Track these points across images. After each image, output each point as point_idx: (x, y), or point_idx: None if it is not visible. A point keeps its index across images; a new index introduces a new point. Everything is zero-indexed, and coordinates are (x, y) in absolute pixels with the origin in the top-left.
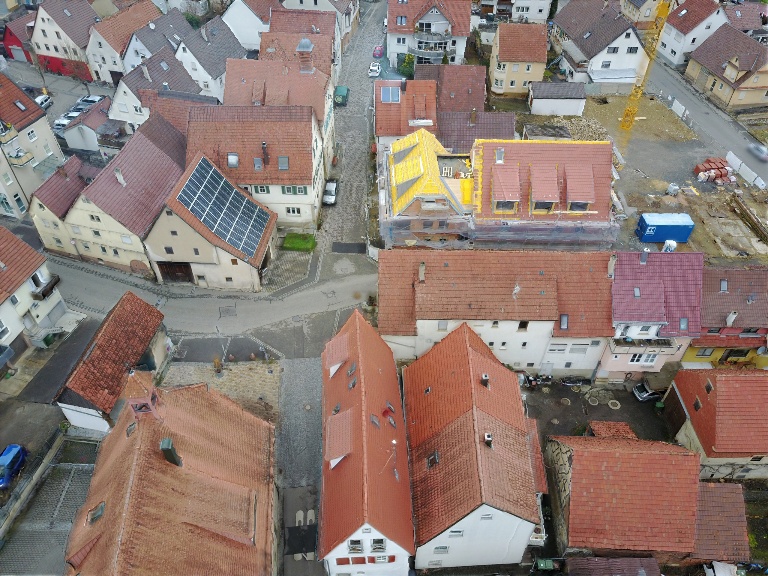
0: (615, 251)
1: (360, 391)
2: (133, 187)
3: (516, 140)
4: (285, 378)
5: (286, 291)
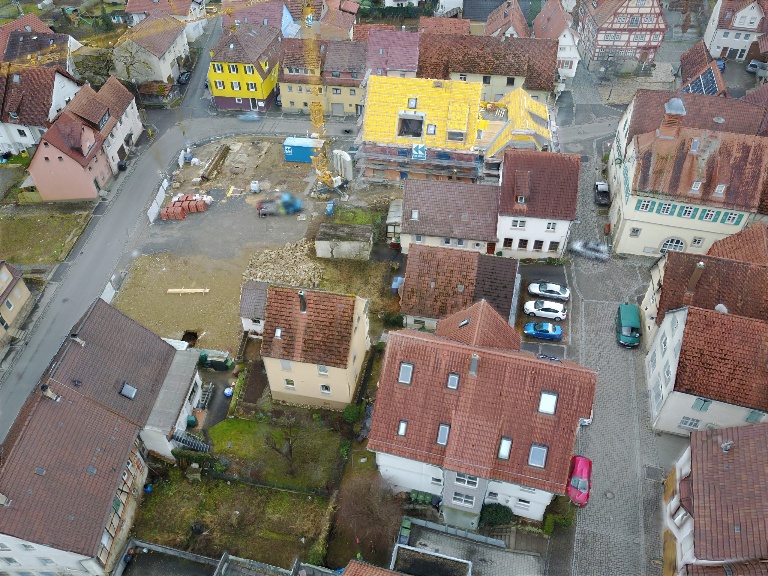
0: (419, 32)
1: (562, 10)
2: (767, 102)
3: (448, 80)
4: (599, 98)
5: (615, 134)
